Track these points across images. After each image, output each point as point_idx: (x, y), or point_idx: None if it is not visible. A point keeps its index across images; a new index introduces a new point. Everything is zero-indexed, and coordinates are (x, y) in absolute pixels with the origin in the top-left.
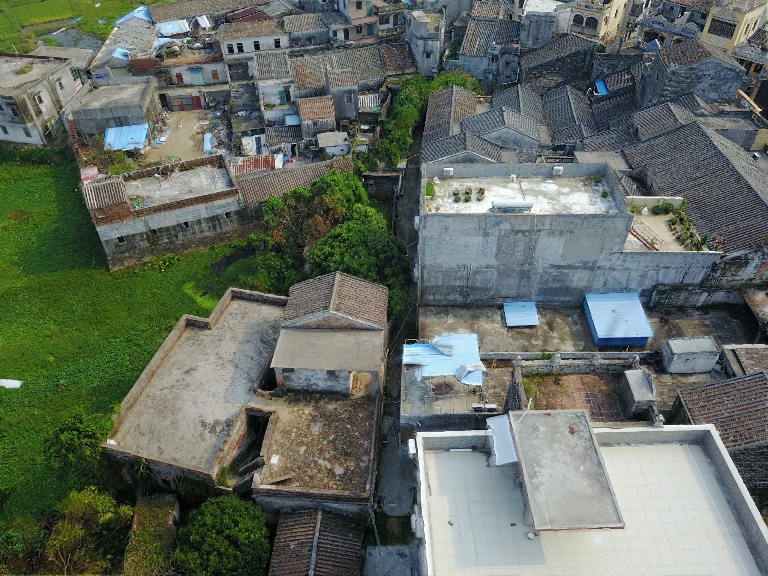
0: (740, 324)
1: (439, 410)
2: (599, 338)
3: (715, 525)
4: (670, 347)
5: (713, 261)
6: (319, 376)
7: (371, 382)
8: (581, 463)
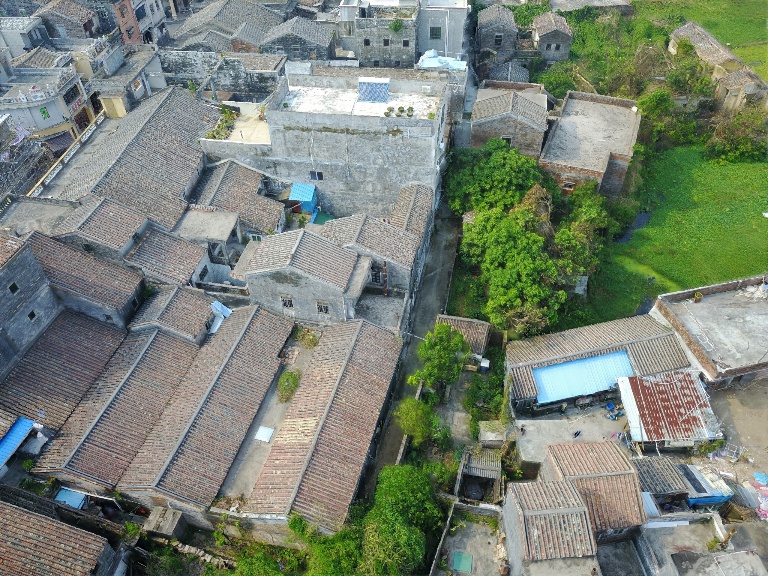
0: None
1: None
2: None
3: None
4: None
5: None
6: None
7: None
8: None
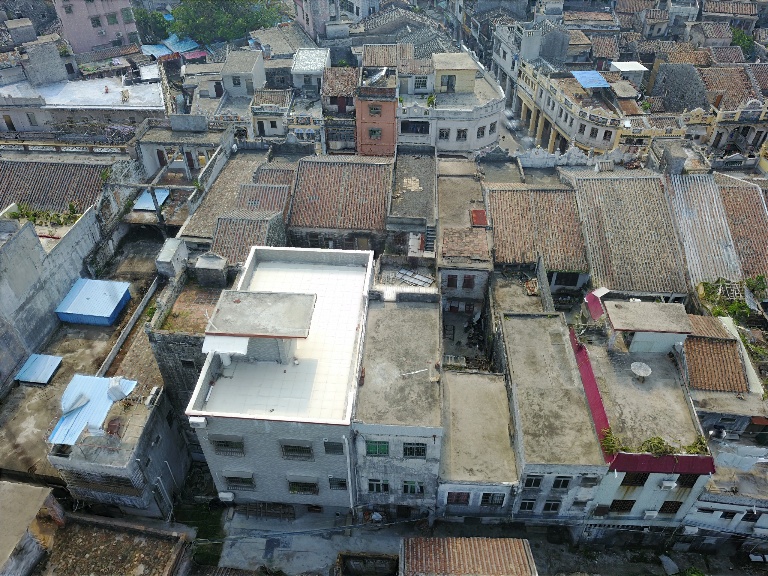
0: (144, 241)
1: (132, 438)
2: (108, 318)
3: (315, 274)
4: (163, 262)
5: (94, 215)
6: (7, 573)
7: (39, 526)
8: (265, 303)
